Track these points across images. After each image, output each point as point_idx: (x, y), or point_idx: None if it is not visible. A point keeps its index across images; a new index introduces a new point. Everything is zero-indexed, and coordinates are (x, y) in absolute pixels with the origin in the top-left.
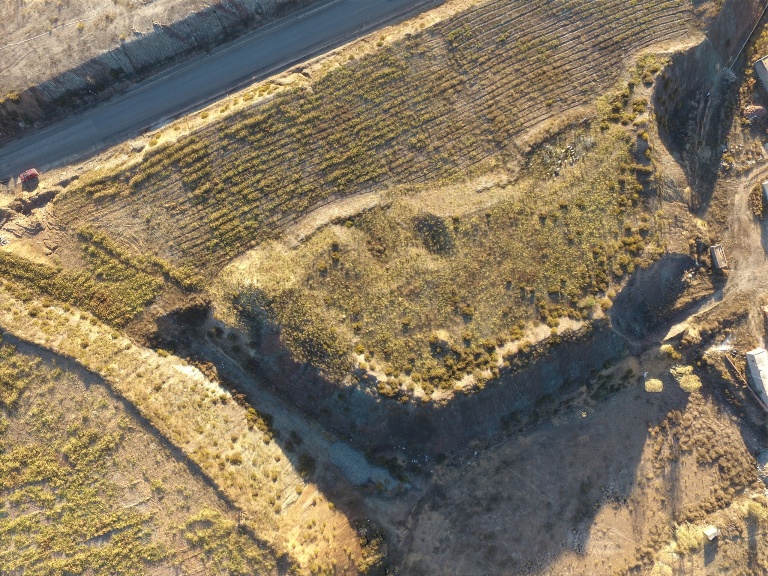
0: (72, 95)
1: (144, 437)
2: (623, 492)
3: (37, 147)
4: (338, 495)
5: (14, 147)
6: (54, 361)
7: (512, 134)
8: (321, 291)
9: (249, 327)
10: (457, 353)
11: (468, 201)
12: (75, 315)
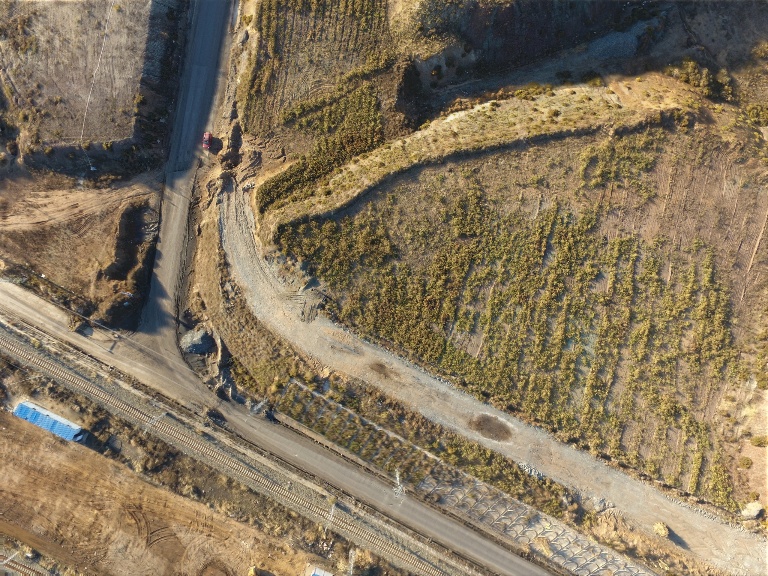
0: (166, 61)
1: (489, 164)
2: None
3: (188, 121)
4: (633, 73)
5: (176, 139)
6: (380, 193)
7: None
8: None
9: (453, 36)
10: None
11: None
12: (349, 167)
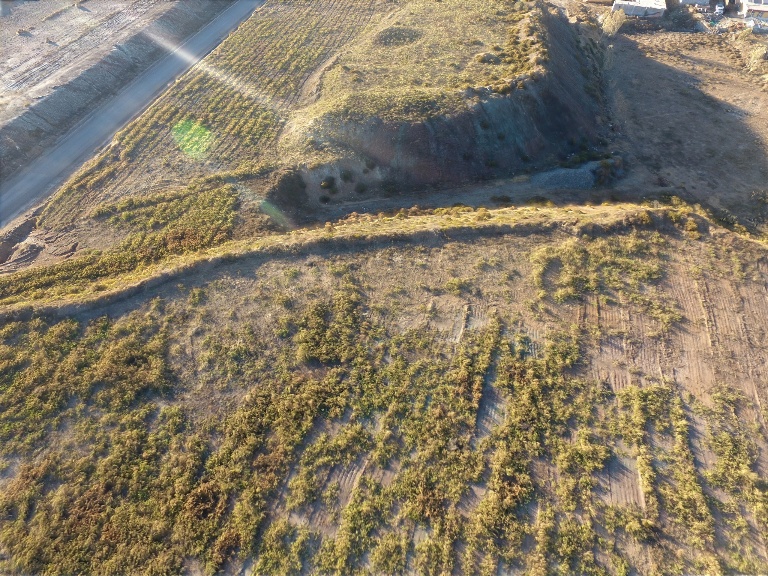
0: None
1: (377, 259)
2: (699, 81)
3: None
4: (596, 201)
5: None
6: (180, 285)
7: (370, 4)
8: (372, 87)
9: (351, 150)
10: (503, 54)
11: (391, 21)
12: (159, 265)
